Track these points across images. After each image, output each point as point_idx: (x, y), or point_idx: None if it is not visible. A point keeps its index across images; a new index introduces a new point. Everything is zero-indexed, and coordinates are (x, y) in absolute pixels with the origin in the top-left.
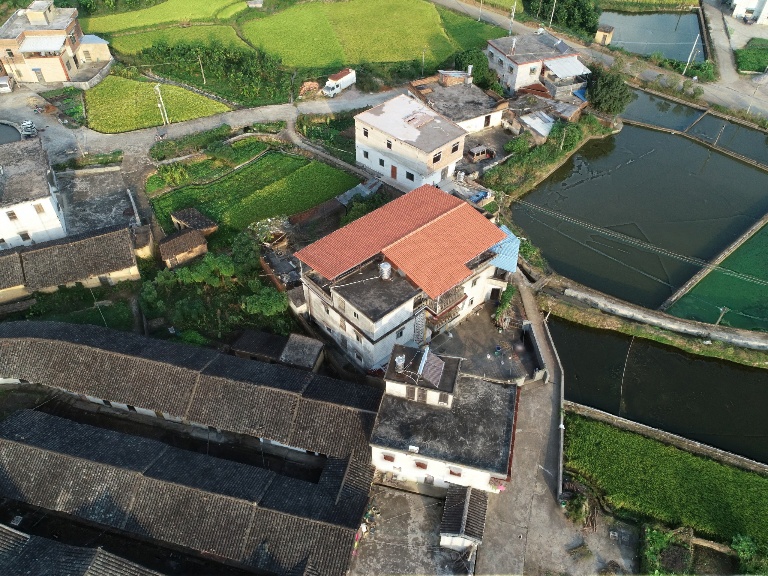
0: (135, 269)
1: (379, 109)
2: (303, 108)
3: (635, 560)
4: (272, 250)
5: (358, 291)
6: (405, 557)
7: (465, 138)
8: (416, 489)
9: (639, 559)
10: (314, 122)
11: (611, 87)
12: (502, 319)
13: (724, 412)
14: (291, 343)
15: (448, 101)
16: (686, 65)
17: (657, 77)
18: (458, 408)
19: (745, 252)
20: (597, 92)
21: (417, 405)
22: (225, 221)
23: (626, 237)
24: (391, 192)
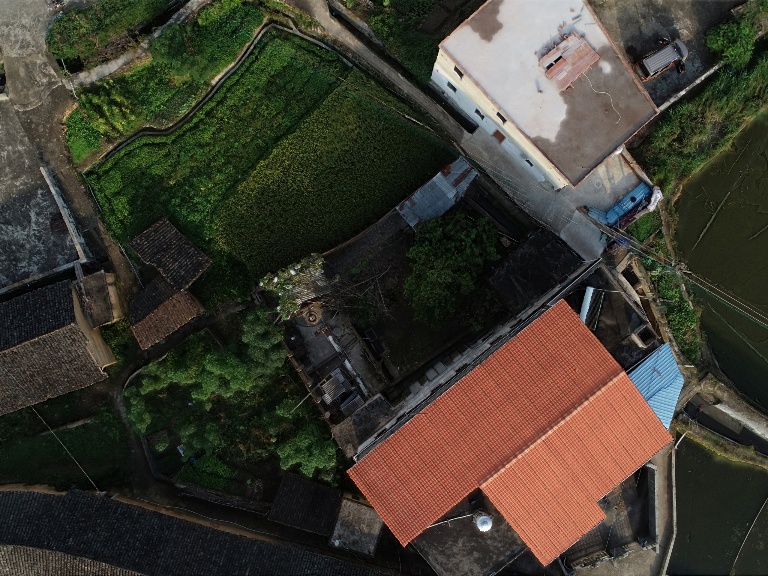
0: (106, 365)
1: (491, 14)
2: None
3: None
4: (301, 314)
5: (441, 541)
6: None
7: None
8: None
9: None
10: None
11: None
12: None
13: None
14: (344, 515)
15: None
16: None
17: None
18: None
19: None
20: None
21: None
22: (219, 242)
23: None
24: (490, 187)
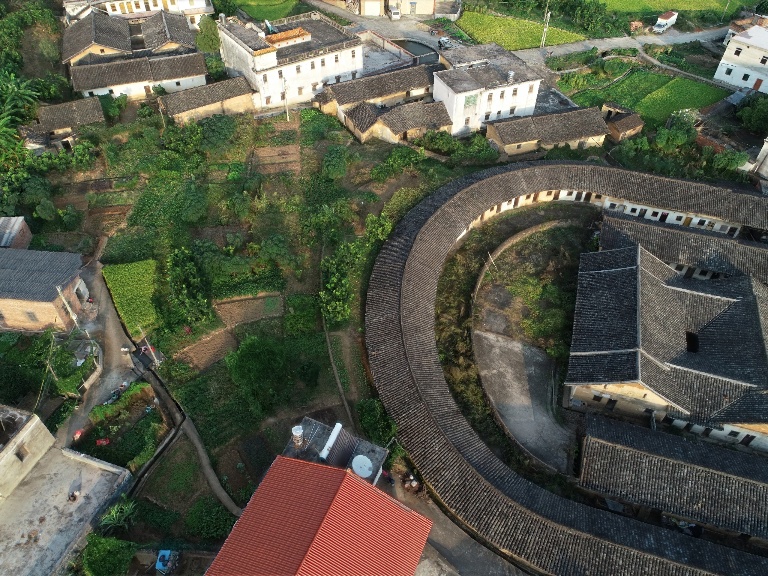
0: (603, 137)
1: (746, 34)
2: (642, 40)
3: None
4: None
5: None
6: None
7: None
8: None
9: None
10: (655, 51)
11: None
12: None
13: None
14: (764, 185)
15: None
16: None
17: None
18: None
19: None
20: None
21: None
22: None
23: None
24: None
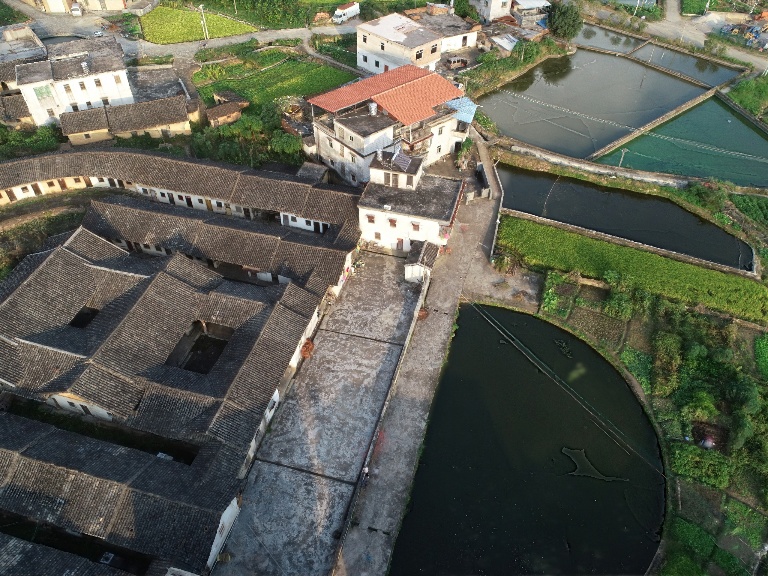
0: (188, 125)
1: (376, 22)
2: (316, 31)
3: (539, 290)
4: (290, 119)
5: (353, 122)
6: (380, 285)
7: (446, 54)
8: (391, 253)
9: (542, 290)
10: (325, 41)
11: (566, 15)
12: (461, 161)
13: (618, 217)
14: (304, 167)
15: (433, 25)
16: (637, 8)
17: (610, 15)
18: (420, 190)
19: (658, 131)
20: (555, 20)
21: (392, 188)
22: (254, 101)
23: (559, 107)
24: None
